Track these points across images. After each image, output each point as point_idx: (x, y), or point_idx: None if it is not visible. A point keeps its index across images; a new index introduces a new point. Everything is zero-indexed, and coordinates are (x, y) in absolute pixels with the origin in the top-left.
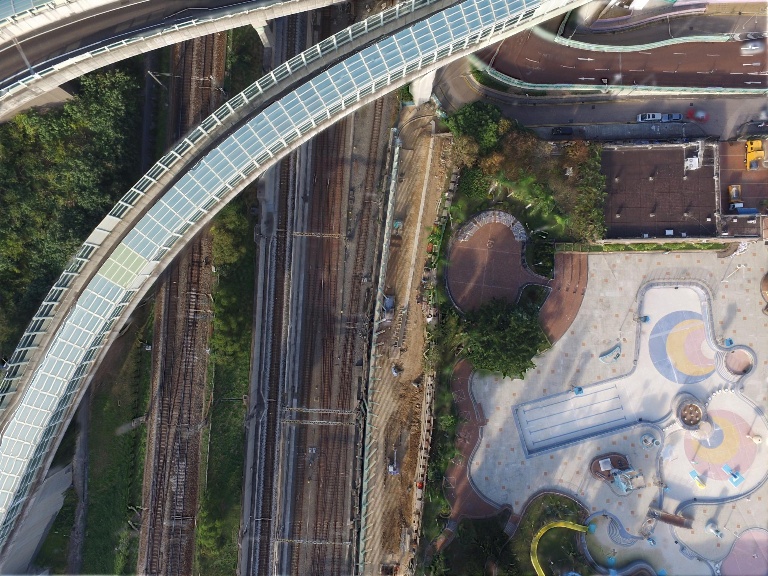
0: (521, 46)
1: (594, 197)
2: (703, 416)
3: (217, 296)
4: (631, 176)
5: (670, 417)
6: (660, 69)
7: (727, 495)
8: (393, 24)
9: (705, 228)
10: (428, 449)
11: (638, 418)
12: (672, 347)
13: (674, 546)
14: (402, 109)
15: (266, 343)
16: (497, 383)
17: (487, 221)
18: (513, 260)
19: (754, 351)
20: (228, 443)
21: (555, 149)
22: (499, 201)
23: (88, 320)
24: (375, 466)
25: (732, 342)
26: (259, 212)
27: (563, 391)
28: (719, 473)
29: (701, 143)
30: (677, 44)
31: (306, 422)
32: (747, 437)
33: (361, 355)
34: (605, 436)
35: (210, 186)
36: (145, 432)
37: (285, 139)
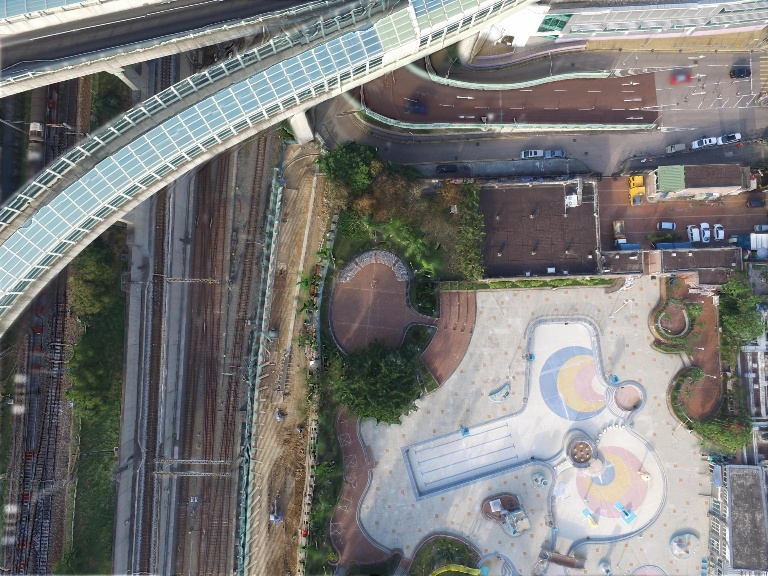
0: (390, 88)
1: (472, 237)
2: (593, 453)
3: None
4: (512, 214)
5: (561, 455)
6: (541, 106)
7: (620, 533)
8: (241, 73)
9: (587, 265)
10: (312, 495)
11: (530, 456)
12: (563, 383)
13: None
14: (286, 148)
15: (143, 391)
16: (386, 424)
17: (368, 262)
18: (398, 300)
19: (643, 386)
20: (98, 497)
21: (440, 187)
22: (382, 241)
23: None
24: (259, 514)
25: (617, 379)
26: (129, 259)
27: (453, 431)
28: (611, 510)
29: (579, 181)
30: (558, 81)
31: (178, 474)
32: (638, 473)
33: (245, 399)
34: (496, 476)
35: (43, 243)
36: (7, 489)
37: (125, 193)
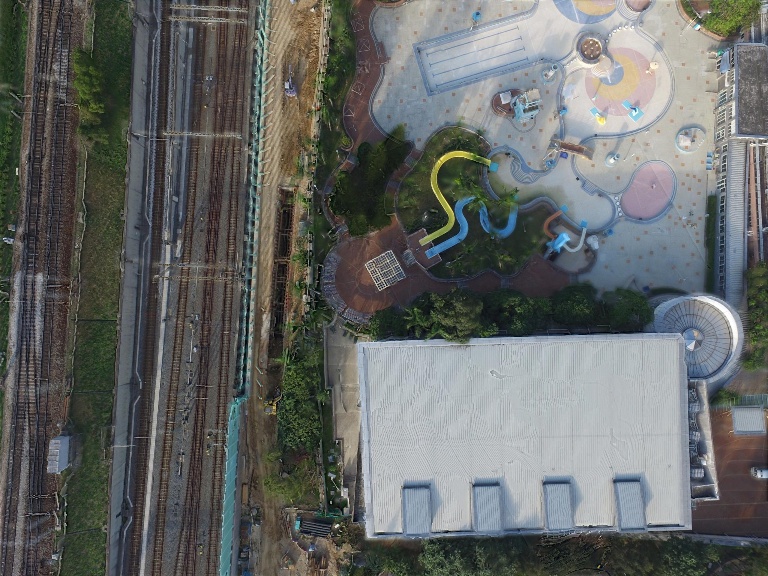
0: None
1: None
2: (603, 49)
3: None
4: None
5: (571, 54)
6: None
7: (627, 130)
8: None
9: None
10: None
11: (540, 58)
12: None
13: (576, 183)
14: None
15: None
16: (399, 22)
17: None
18: None
19: None
20: (115, 42)
21: None
22: None
23: None
24: (273, 92)
25: None
26: None
27: (464, 28)
28: (619, 109)
29: None
30: None
31: (194, 18)
32: (646, 72)
33: None
34: (506, 73)
35: None
36: (26, 20)
37: None
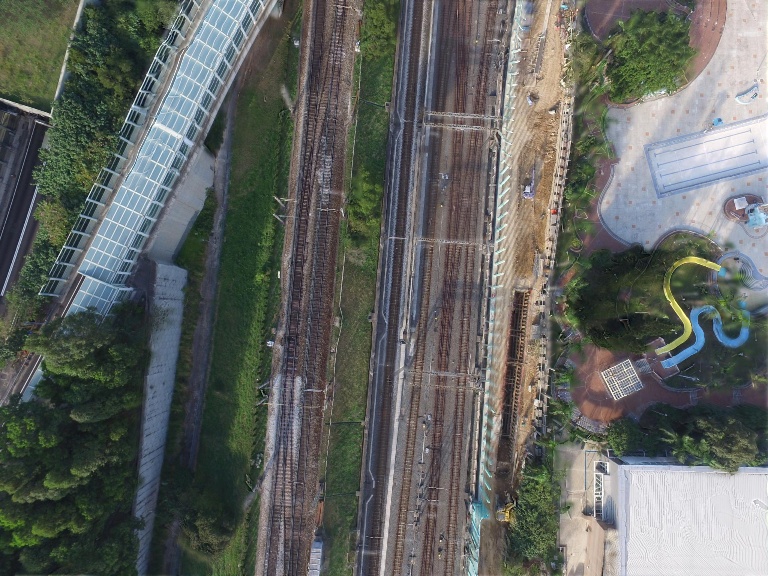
0: None
1: None
2: None
3: None
4: None
5: None
6: None
7: None
8: None
9: None
10: (563, 175)
11: None
12: None
13: None
14: None
15: (403, 63)
16: (630, 122)
17: None
18: None
19: None
20: (371, 146)
21: None
22: None
23: None
24: (509, 193)
25: None
26: None
27: (697, 131)
28: None
29: None
30: None
31: (450, 126)
32: None
33: (494, 87)
34: (740, 177)
35: None
36: (291, 126)
37: None
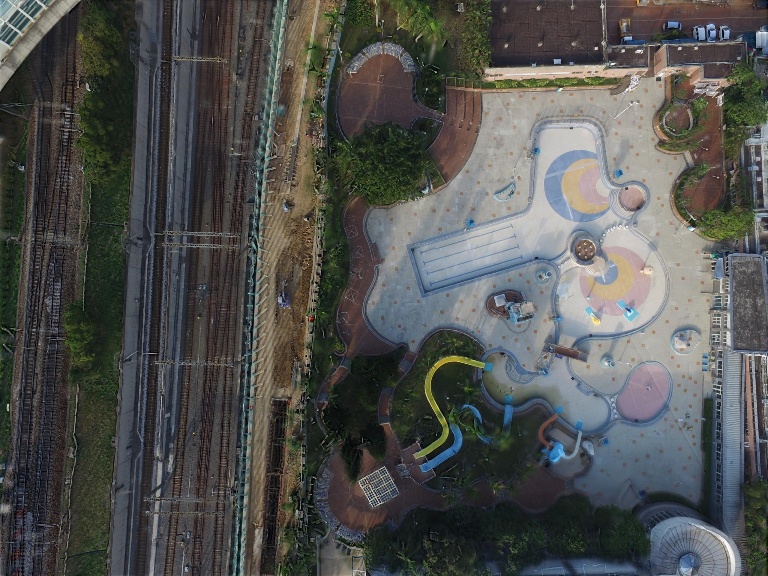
0: None
1: (479, 22)
2: (597, 251)
3: (84, 102)
4: (519, 6)
5: (565, 254)
6: None
7: (622, 330)
8: None
9: (593, 58)
10: (319, 282)
11: (534, 257)
12: (567, 186)
13: (571, 382)
14: None
15: (152, 176)
16: (392, 223)
17: (375, 52)
18: (404, 95)
19: (647, 187)
20: (108, 268)
21: None
22: (389, 35)
23: None
24: (266, 301)
25: (622, 172)
26: (137, 34)
27: (458, 229)
28: (614, 308)
29: None
30: None
31: (187, 245)
32: (641, 272)
33: (253, 193)
34: (501, 273)
35: None
36: (19, 253)
37: None
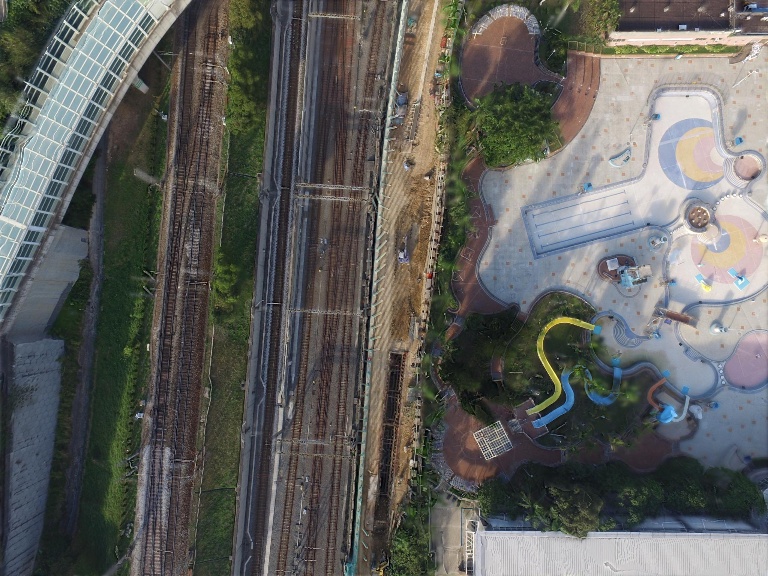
0: None
1: None
2: (711, 218)
3: (234, 52)
4: None
5: (678, 221)
6: None
7: (732, 298)
8: None
9: (718, 24)
10: (438, 240)
11: (646, 223)
12: (682, 154)
13: (678, 348)
14: None
15: (280, 131)
16: (507, 185)
17: (501, 14)
18: (526, 58)
19: (763, 156)
20: (242, 217)
21: None
22: None
23: (109, 35)
24: (385, 257)
25: (742, 140)
26: None
27: (572, 193)
28: (725, 276)
29: None
30: None
31: (319, 197)
32: (754, 241)
33: (373, 152)
34: (613, 238)
35: None
36: (160, 200)
37: None
